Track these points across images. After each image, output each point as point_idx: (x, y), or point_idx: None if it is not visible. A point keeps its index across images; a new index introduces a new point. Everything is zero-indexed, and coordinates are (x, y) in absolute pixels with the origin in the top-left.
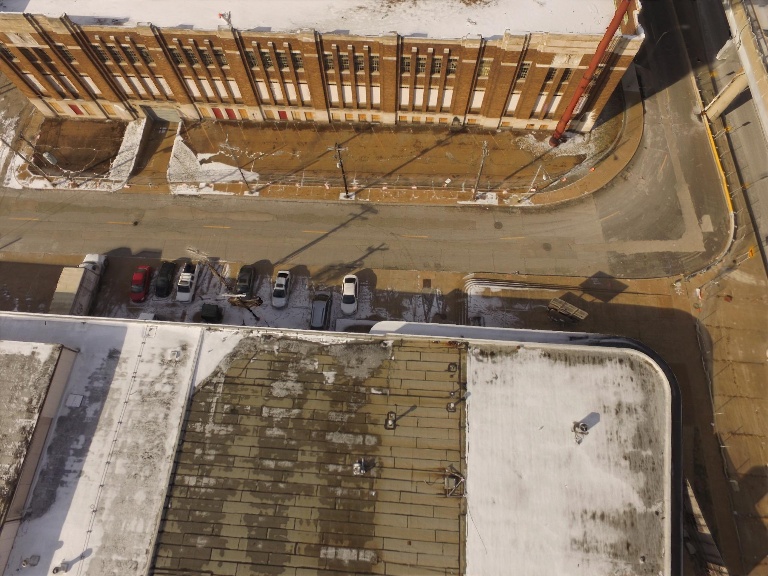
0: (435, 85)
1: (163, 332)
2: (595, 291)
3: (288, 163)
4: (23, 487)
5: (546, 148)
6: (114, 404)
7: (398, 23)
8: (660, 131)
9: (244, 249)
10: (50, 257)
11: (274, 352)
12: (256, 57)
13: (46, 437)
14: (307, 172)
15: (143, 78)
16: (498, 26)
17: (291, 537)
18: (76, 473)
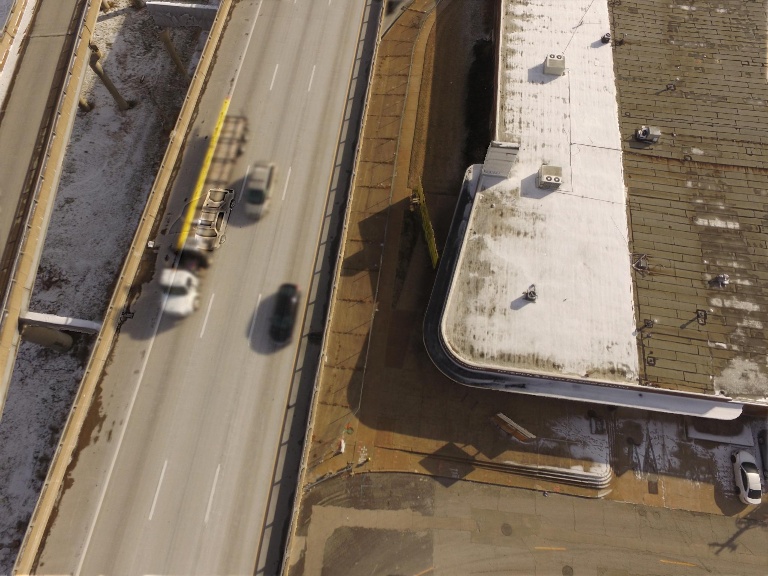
0: None
1: None
2: (460, 458)
3: None
4: None
5: None
6: None
7: None
8: None
9: None
10: None
11: None
12: None
13: None
14: None
15: None
16: None
17: (766, 236)
18: None
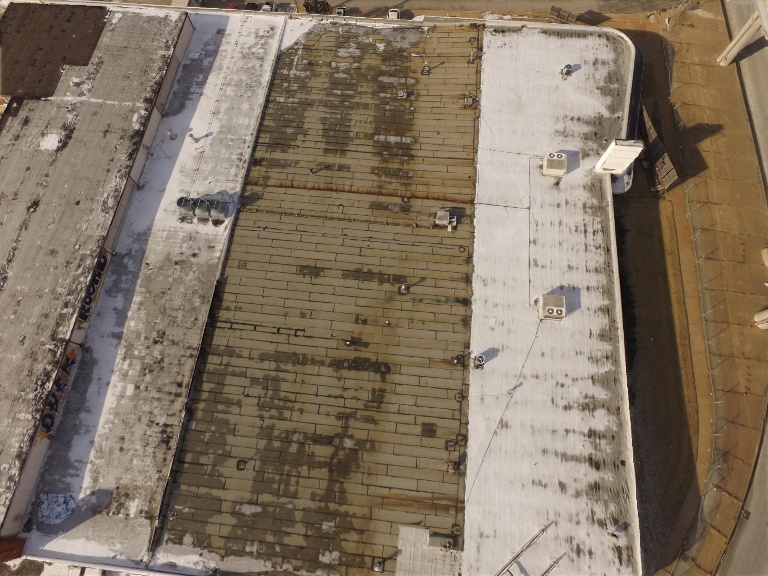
0: None
1: (256, 20)
2: (585, 20)
3: None
4: (164, 93)
5: None
6: (223, 58)
7: None
8: None
9: None
10: (158, 2)
11: (339, 32)
12: None
13: (176, 72)
14: None
15: None
16: None
17: (353, 129)
18: (198, 94)
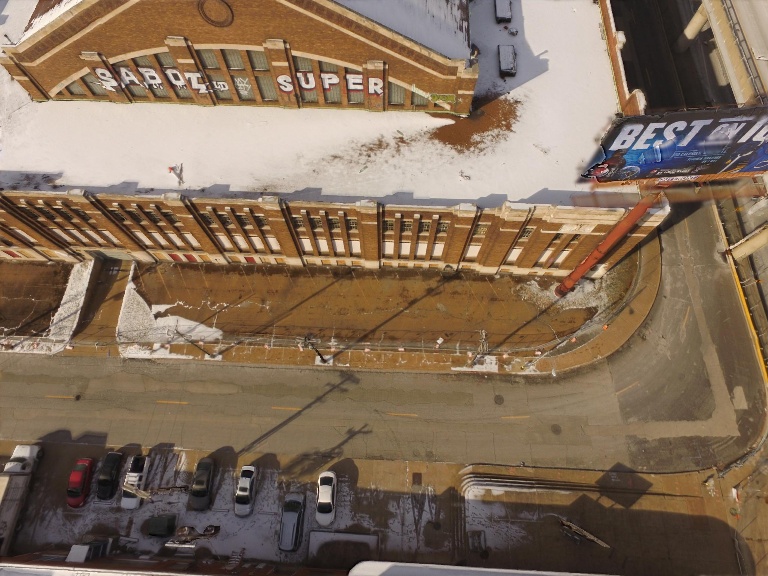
0: (423, 240)
1: None
2: (614, 492)
3: (256, 317)
4: None
5: (552, 299)
6: None
7: (379, 178)
8: (680, 275)
9: (203, 432)
10: None
11: None
12: (213, 218)
13: None
14: (278, 329)
15: (84, 230)
16: (496, 181)
17: None
18: None
